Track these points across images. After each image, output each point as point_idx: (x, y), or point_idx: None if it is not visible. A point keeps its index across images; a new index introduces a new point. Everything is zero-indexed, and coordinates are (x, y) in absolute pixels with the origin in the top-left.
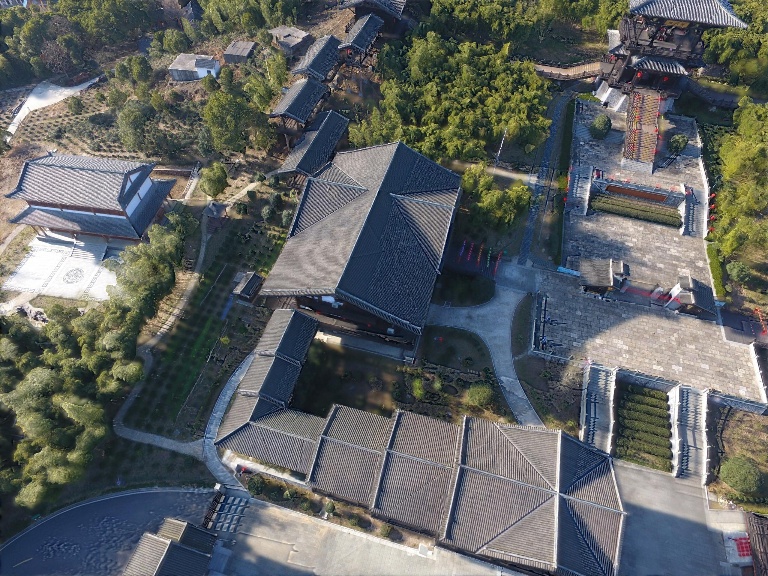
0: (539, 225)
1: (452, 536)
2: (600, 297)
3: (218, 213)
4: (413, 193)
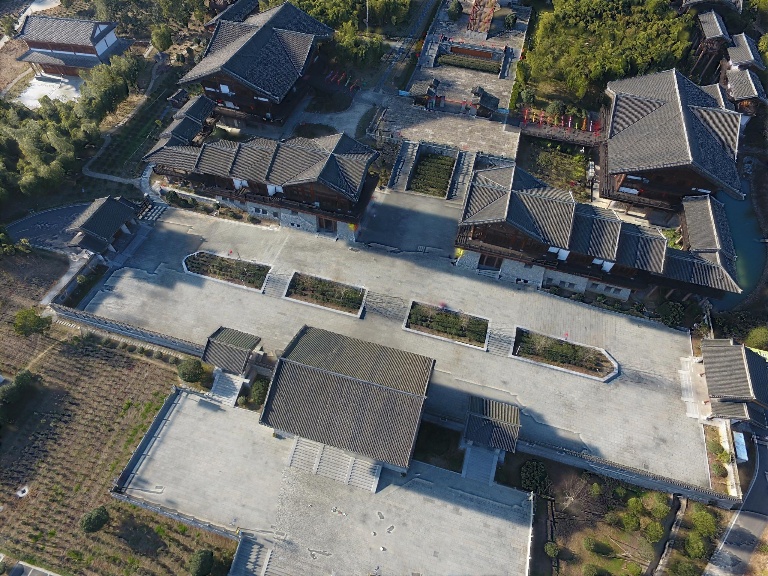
0: (395, 71)
1: (270, 179)
2: (425, 109)
3: (163, 58)
4: None
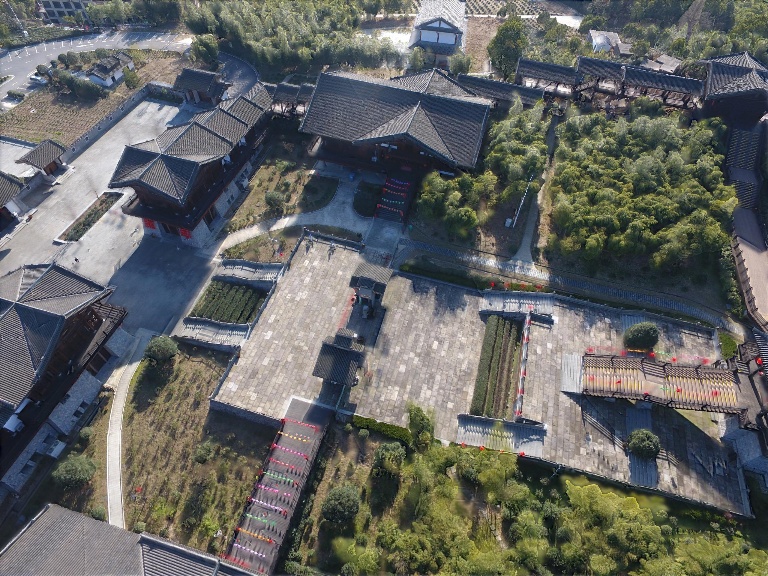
0: (453, 260)
1: None
2: None
3: None
4: (430, 121)
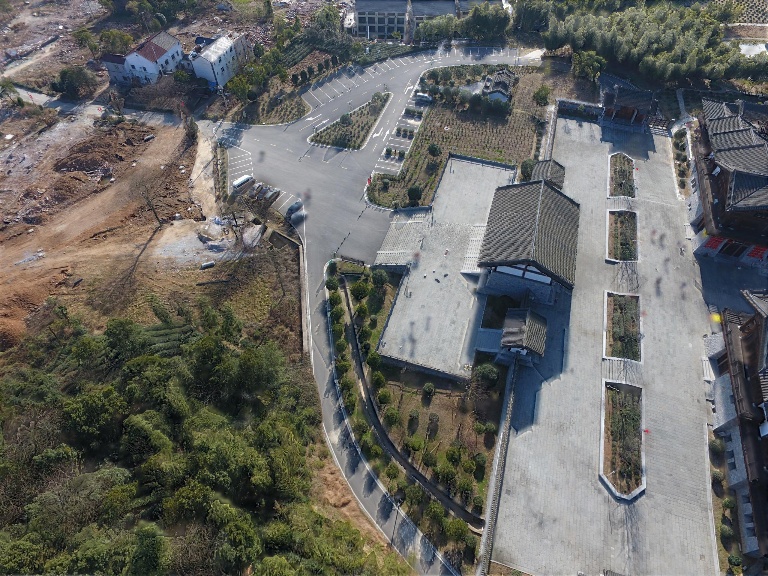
0: None
1: None
2: None
3: None
4: None
